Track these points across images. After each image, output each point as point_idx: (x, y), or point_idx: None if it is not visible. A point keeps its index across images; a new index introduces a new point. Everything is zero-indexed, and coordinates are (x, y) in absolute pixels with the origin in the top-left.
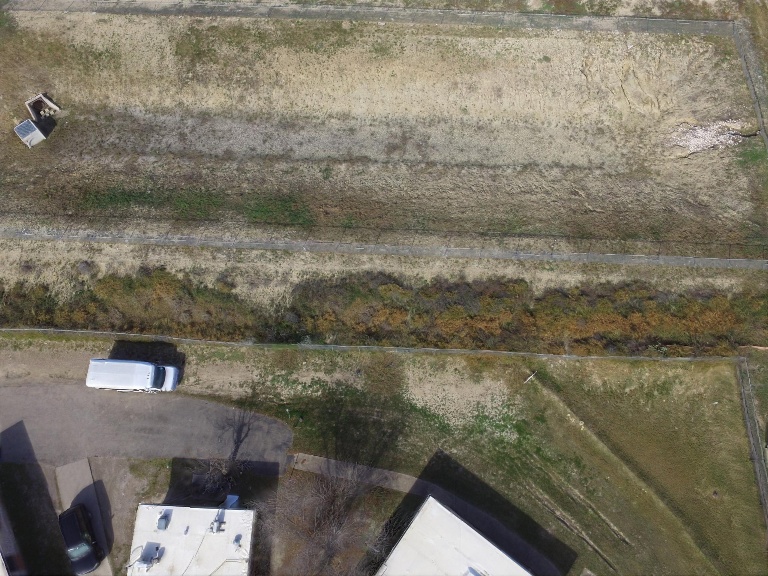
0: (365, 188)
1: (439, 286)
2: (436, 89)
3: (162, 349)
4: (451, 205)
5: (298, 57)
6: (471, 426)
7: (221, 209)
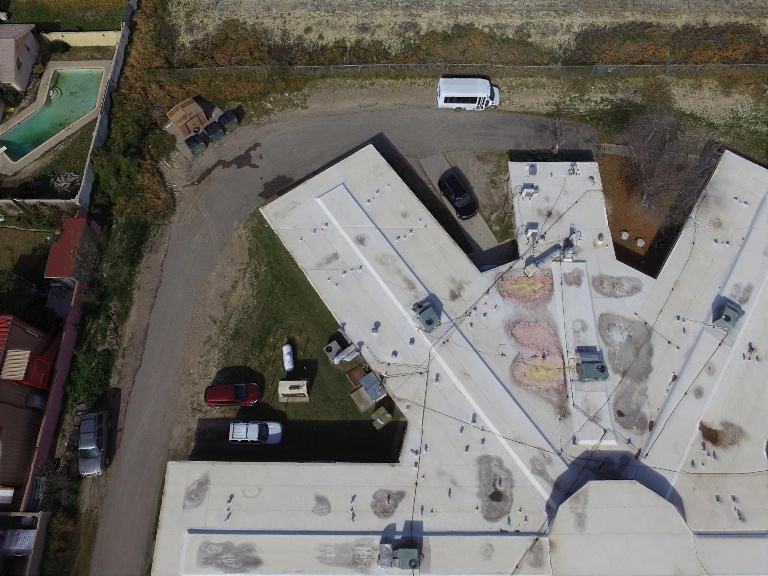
0: None
1: None
2: None
3: None
4: None
5: None
6: (731, 124)
7: None
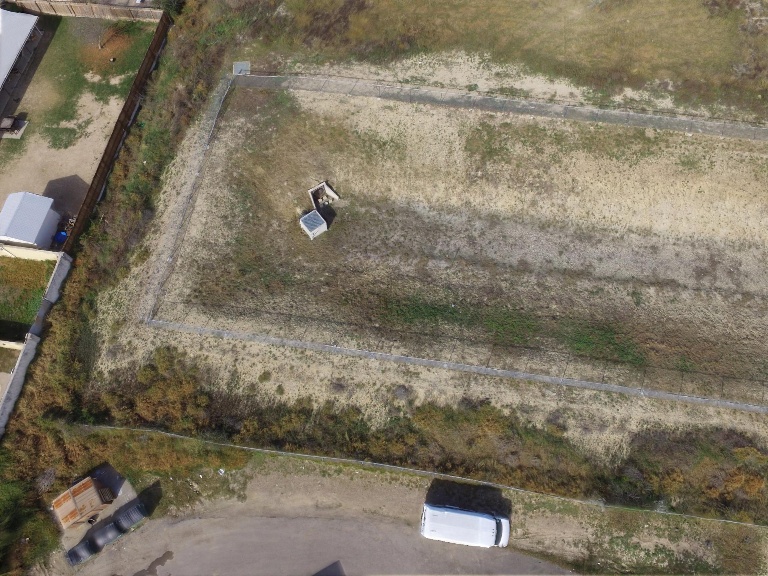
0: (685, 321)
1: None
2: (747, 211)
3: (486, 492)
4: None
5: (597, 163)
6: None
7: (538, 335)
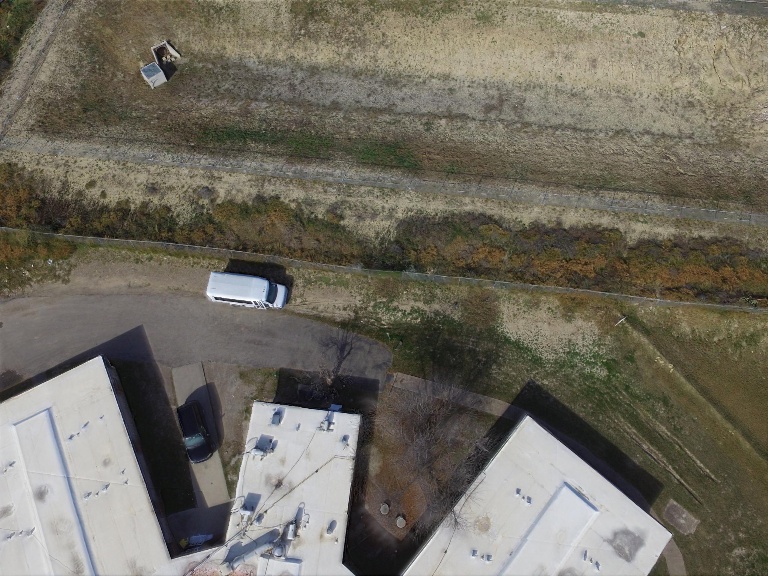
0: (464, 141)
1: (537, 229)
2: (533, 57)
3: (272, 271)
4: (547, 160)
5: (404, 20)
6: (562, 361)
7: (331, 150)
